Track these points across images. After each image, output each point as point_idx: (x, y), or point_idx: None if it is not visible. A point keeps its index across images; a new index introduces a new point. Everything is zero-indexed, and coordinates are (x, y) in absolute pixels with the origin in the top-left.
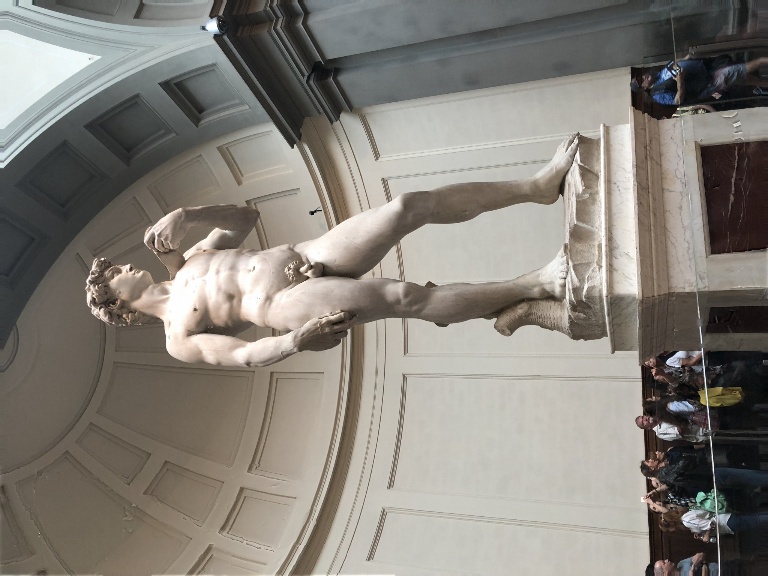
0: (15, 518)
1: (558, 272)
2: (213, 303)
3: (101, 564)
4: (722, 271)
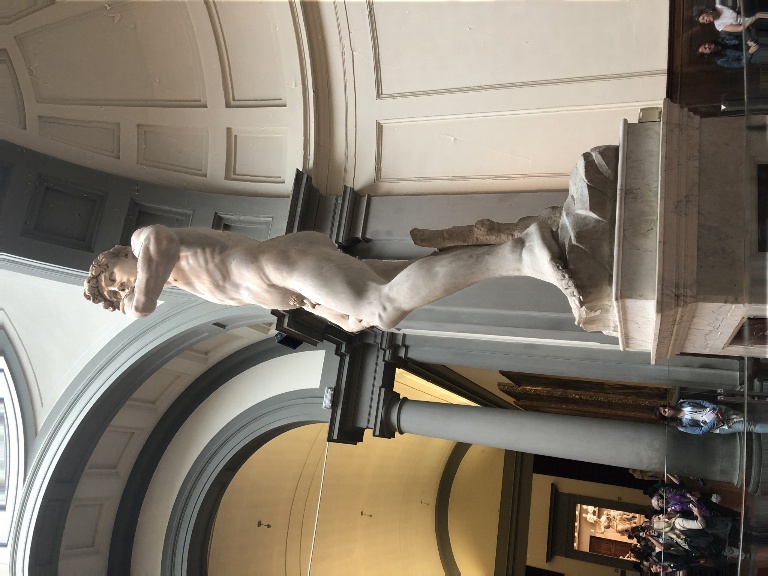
0: (76, 120)
1: None
2: None
3: (151, 71)
4: None
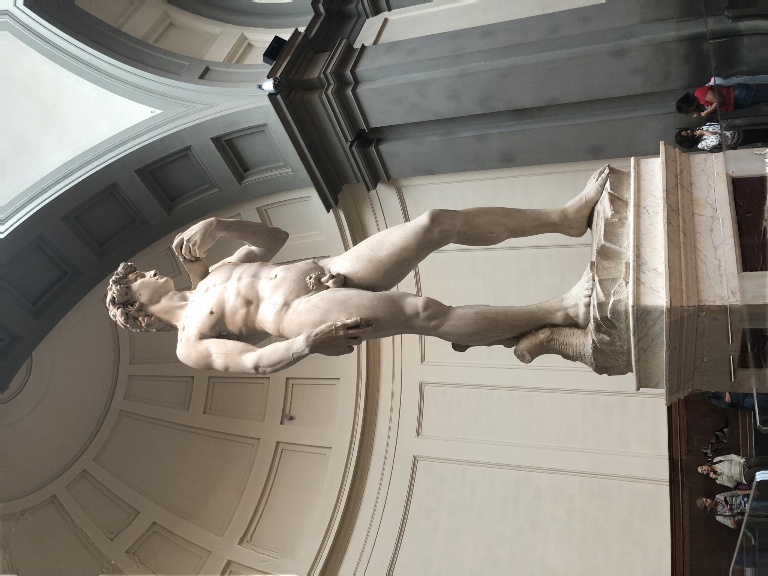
0: None
1: (583, 291)
2: (230, 307)
3: None
4: (755, 286)
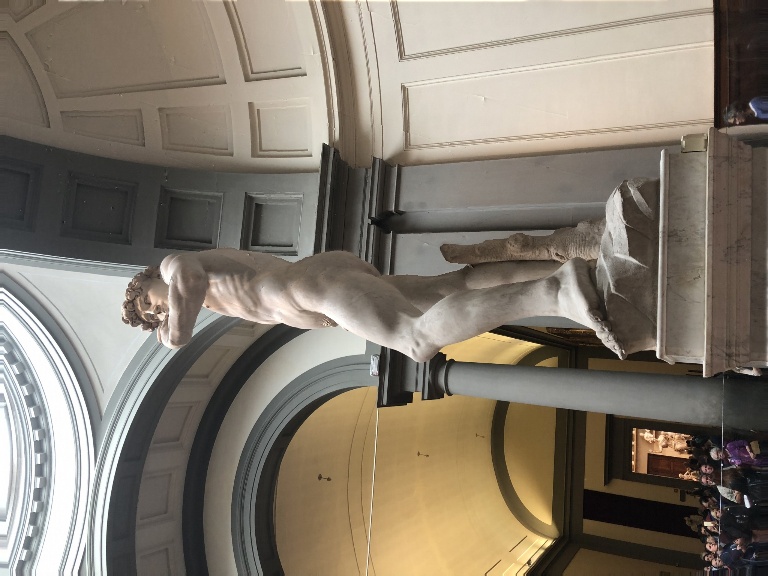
0: (98, 111)
1: None
2: None
3: (165, 50)
4: None
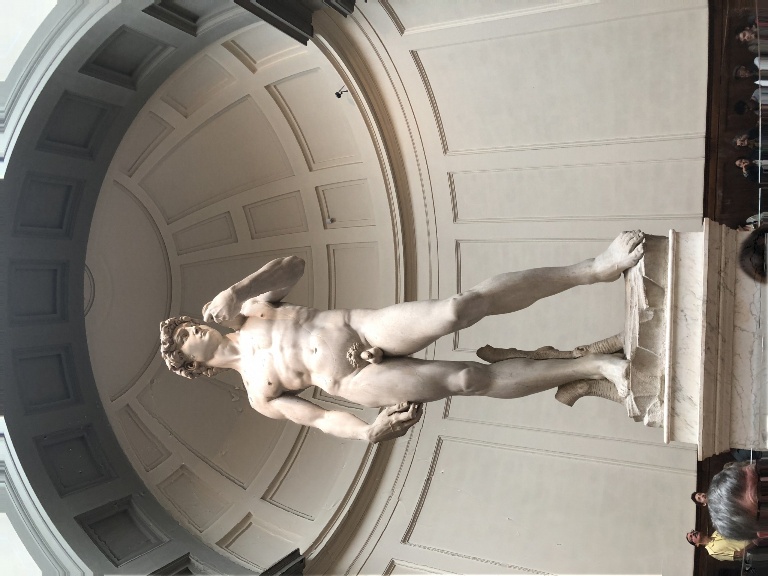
0: (147, 427)
1: (619, 386)
2: (285, 378)
3: (225, 444)
4: None
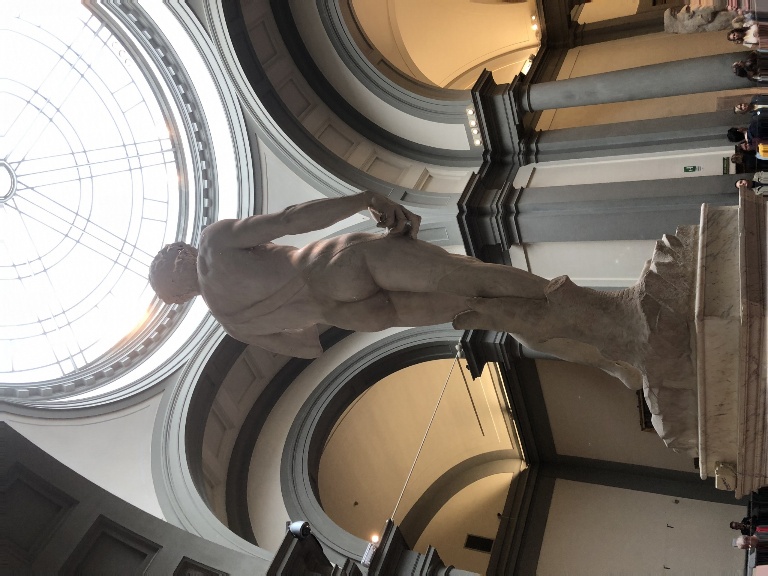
0: None
1: None
2: None
3: None
4: None
